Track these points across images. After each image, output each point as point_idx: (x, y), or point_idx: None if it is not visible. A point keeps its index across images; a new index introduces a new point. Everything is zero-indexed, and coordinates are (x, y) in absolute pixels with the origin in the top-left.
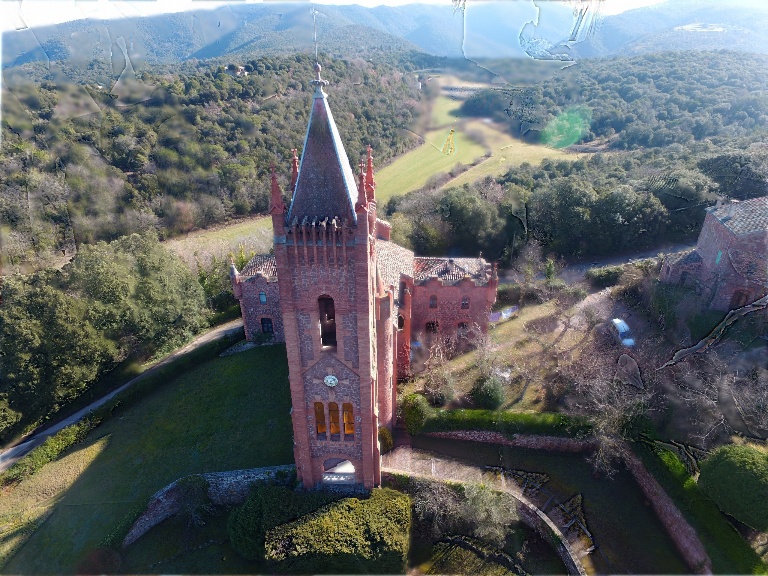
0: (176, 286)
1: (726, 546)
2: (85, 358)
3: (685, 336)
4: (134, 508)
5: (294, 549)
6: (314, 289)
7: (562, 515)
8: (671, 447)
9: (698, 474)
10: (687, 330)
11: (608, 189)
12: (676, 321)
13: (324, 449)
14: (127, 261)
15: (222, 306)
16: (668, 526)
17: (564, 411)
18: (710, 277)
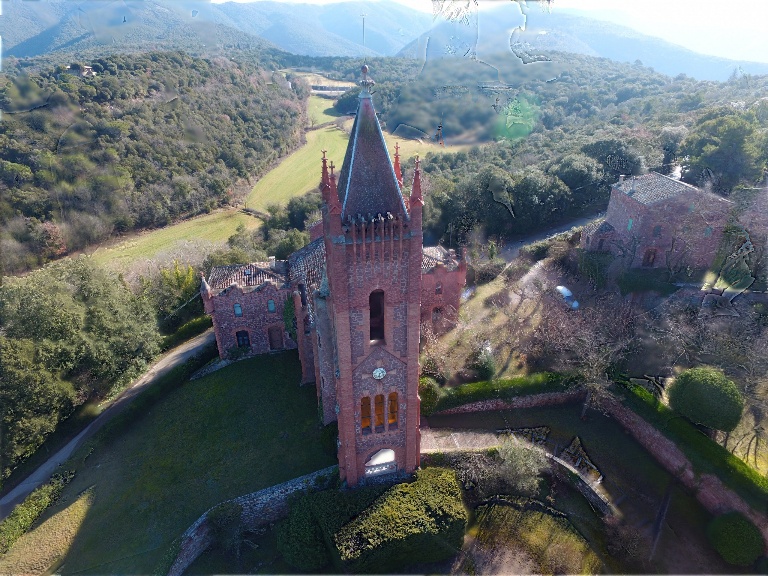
0: (127, 312)
1: (702, 448)
2: (40, 407)
3: (616, 292)
4: (167, 553)
5: (367, 543)
6: (368, 285)
7: (570, 457)
8: (642, 381)
9: (666, 399)
10: (617, 287)
11: (520, 175)
12: (605, 281)
13: (368, 443)
14: (68, 290)
15: (161, 329)
16: (648, 446)
17: (555, 368)
18: (624, 242)
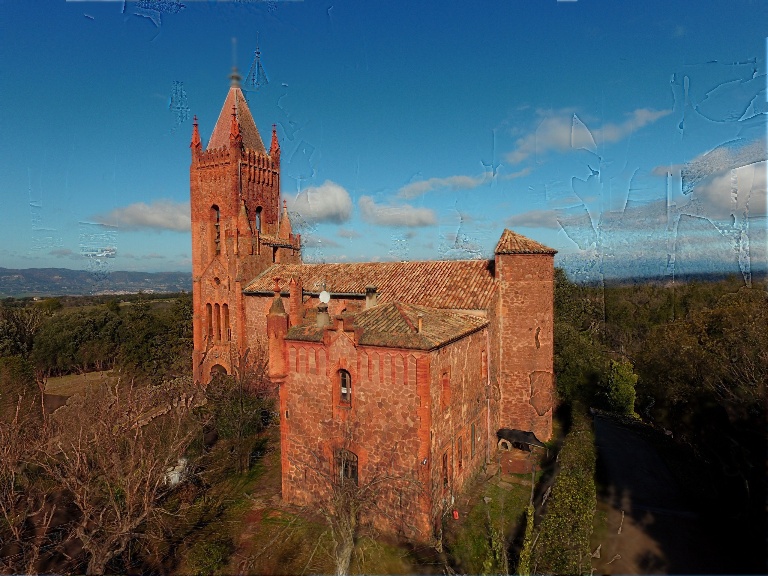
0: None
1: None
2: None
3: None
4: None
5: None
6: None
7: None
8: None
9: None
10: None
11: None
12: None
13: None
14: None
15: None
16: None
17: None
18: None
